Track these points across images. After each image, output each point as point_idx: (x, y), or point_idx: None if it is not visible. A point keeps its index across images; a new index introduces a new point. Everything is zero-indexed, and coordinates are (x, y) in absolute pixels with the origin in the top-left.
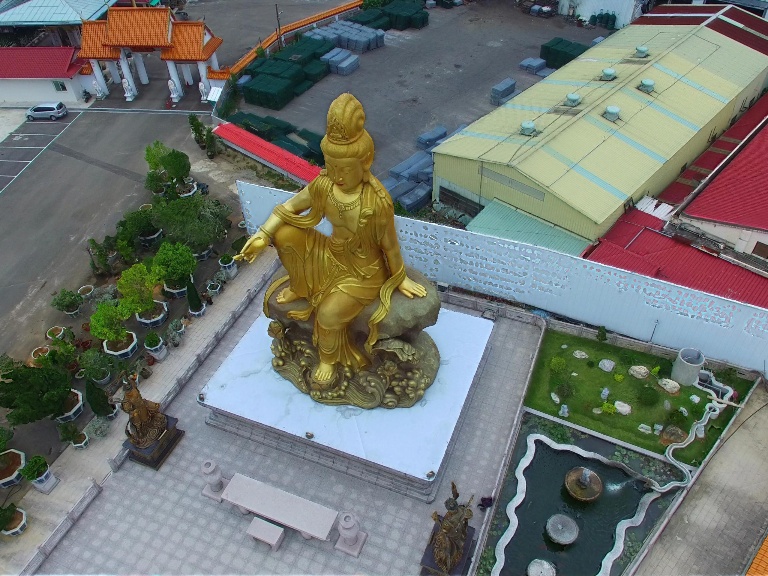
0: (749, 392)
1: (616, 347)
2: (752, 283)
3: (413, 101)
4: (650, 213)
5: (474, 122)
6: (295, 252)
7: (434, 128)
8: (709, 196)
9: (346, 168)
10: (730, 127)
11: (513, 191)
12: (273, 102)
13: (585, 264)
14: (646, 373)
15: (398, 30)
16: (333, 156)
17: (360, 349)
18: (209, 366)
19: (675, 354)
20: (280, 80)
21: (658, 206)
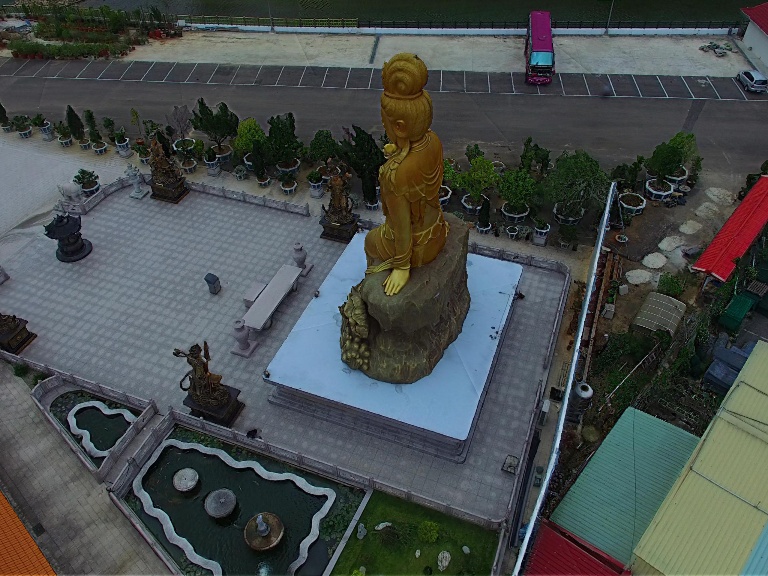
0: None
1: None
2: None
3: None
4: None
5: None
6: None
7: None
8: None
9: None
10: None
11: None
12: None
13: None
14: None
15: None
16: None
17: None
18: None
19: None
20: None
21: None
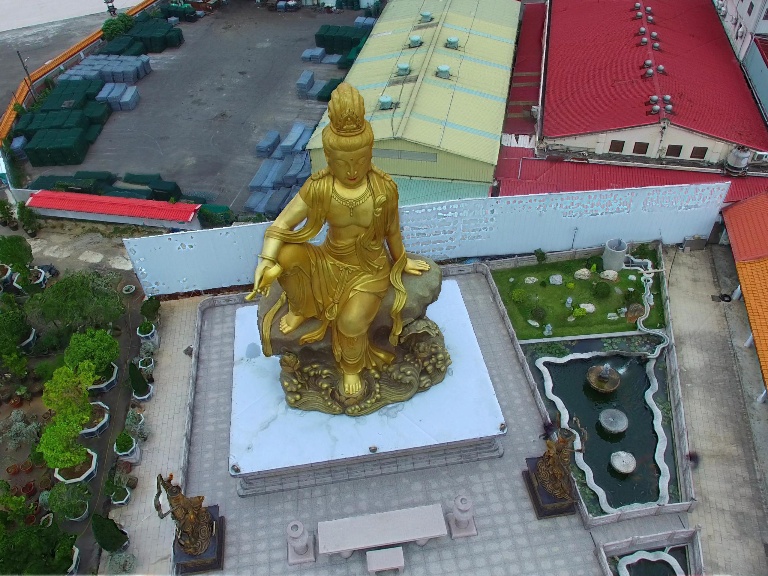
0: (662, 257)
1: (548, 264)
2: (623, 174)
3: (222, 116)
4: (517, 146)
5: (325, 112)
6: (301, 271)
7: (266, 134)
8: (552, 118)
9: (361, 159)
10: (515, 64)
11: (404, 162)
12: (71, 156)
13: (508, 200)
14: (589, 273)
15: (156, 53)
16: (348, 150)
17: (378, 347)
18: (200, 442)
19: (594, 251)
20: (68, 131)
21: (518, 139)
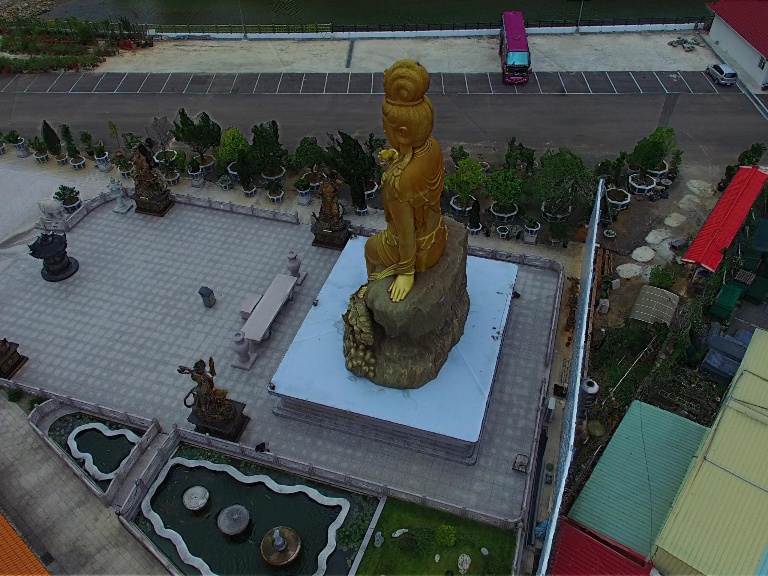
0: None
1: None
2: None
3: None
4: None
5: None
6: None
7: None
8: None
9: None
10: None
11: None
12: None
13: None
14: None
15: None
16: None
17: None
18: None
19: None
20: None
21: None
